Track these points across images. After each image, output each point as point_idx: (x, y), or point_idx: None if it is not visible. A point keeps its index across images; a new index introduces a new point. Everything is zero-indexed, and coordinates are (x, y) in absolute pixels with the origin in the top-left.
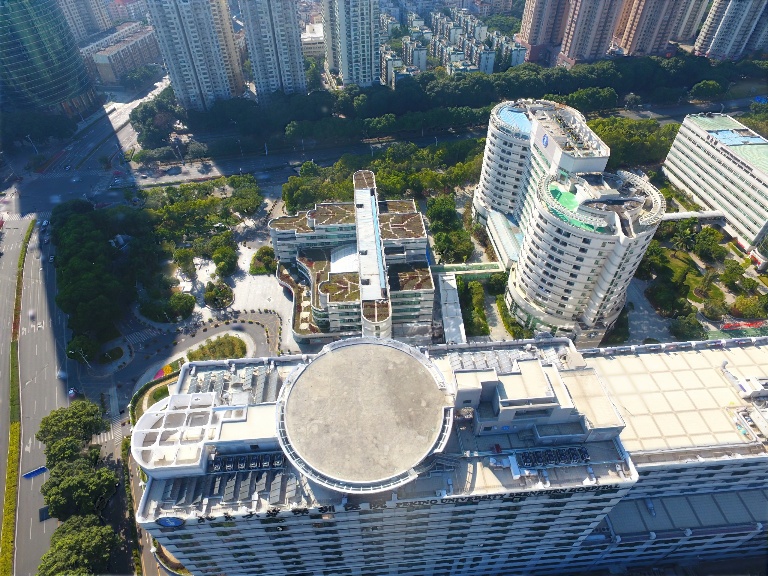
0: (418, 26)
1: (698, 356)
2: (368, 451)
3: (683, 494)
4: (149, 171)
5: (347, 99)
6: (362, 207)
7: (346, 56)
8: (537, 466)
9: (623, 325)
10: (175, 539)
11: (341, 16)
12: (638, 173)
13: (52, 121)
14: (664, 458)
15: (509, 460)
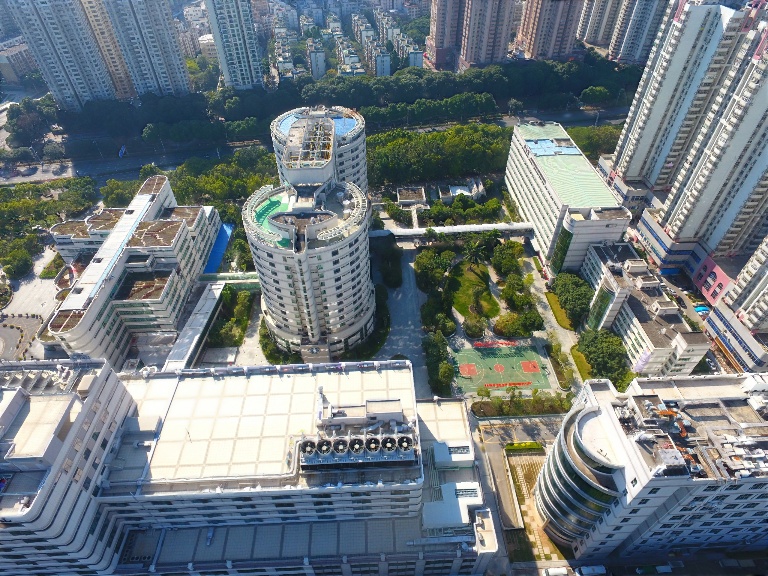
0: (331, 28)
1: (310, 379)
2: None
3: (252, 524)
4: (5, 171)
5: (218, 102)
6: (132, 213)
7: (224, 58)
8: None
9: (375, 340)
10: None
11: (212, 18)
12: (477, 182)
13: None
14: (186, 487)
15: None
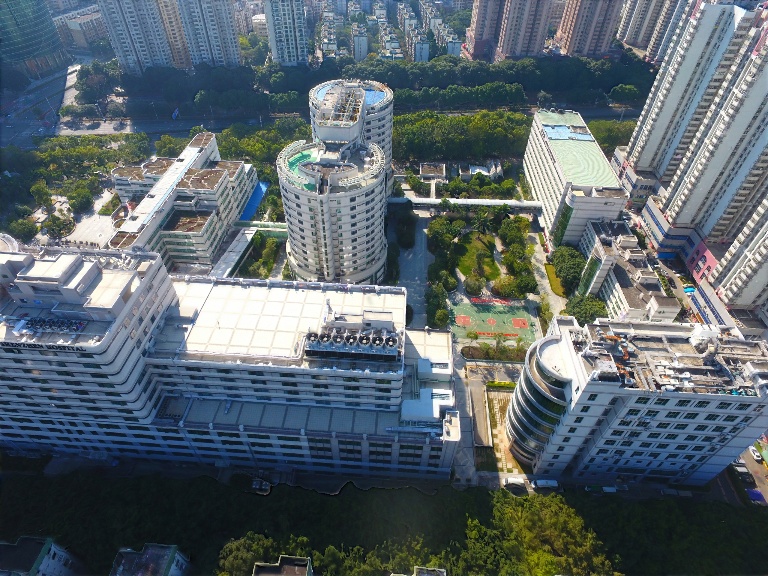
0: (376, 15)
1: (320, 294)
2: None
3: (262, 402)
4: (73, 124)
5: (265, 75)
6: (183, 161)
7: (274, 36)
8: (38, 329)
9: None
10: None
11: None
12: (496, 163)
13: (5, 75)
14: (213, 359)
15: (19, 322)
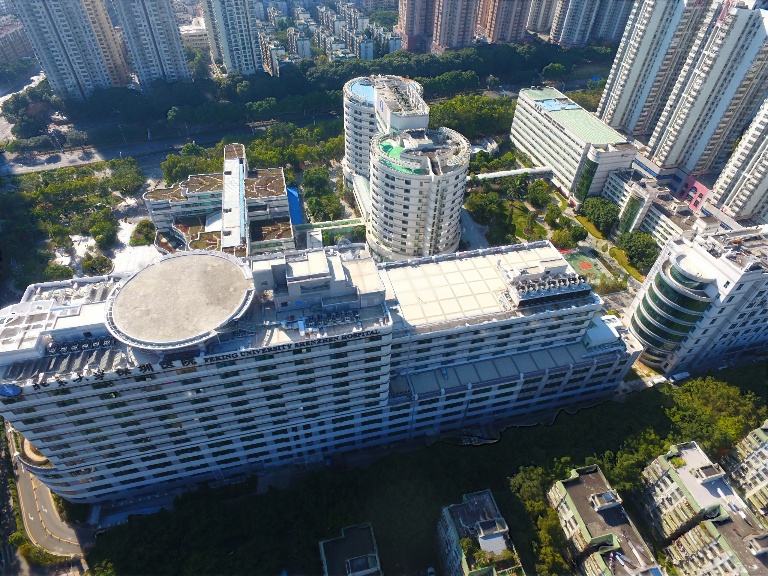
0: (303, 19)
1: (483, 259)
2: (179, 323)
3: (470, 362)
4: (25, 161)
5: (230, 86)
6: (230, 174)
7: (227, 45)
8: (320, 325)
9: None
10: (20, 414)
11: (216, 6)
12: (490, 141)
13: None
14: (442, 328)
15: (298, 323)
